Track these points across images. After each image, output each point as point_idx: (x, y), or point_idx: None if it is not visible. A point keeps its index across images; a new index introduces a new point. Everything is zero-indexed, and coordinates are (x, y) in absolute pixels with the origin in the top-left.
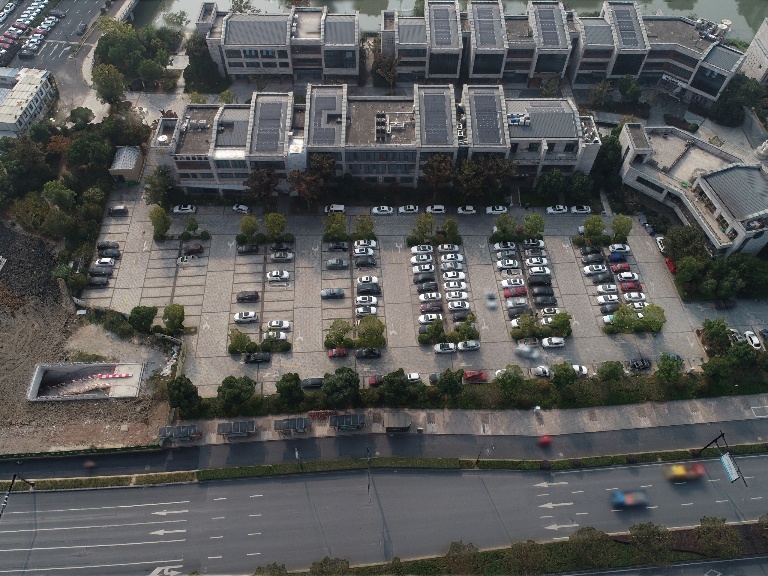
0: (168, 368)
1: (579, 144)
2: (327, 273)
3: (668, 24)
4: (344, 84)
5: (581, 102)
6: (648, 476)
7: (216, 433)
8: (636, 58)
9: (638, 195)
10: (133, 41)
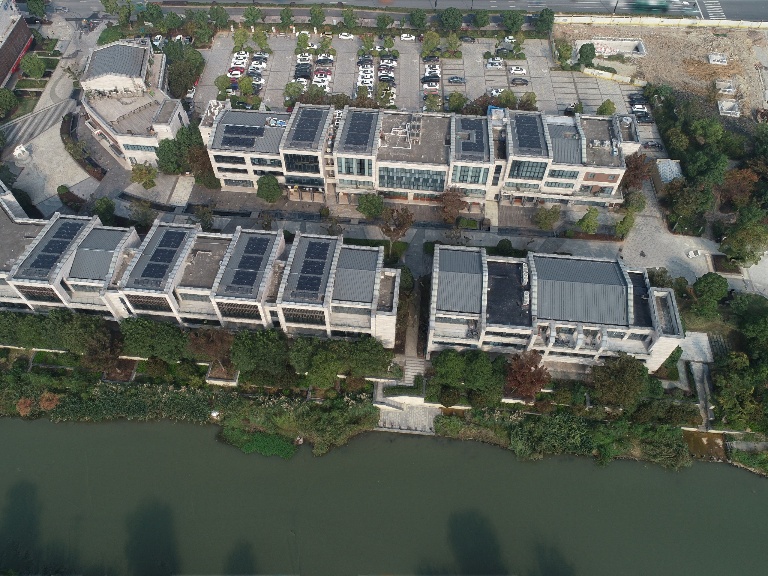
0: None
1: None
2: None
3: None
4: (454, 161)
5: None
6: (287, 2)
7: (522, 26)
8: None
9: None
10: None
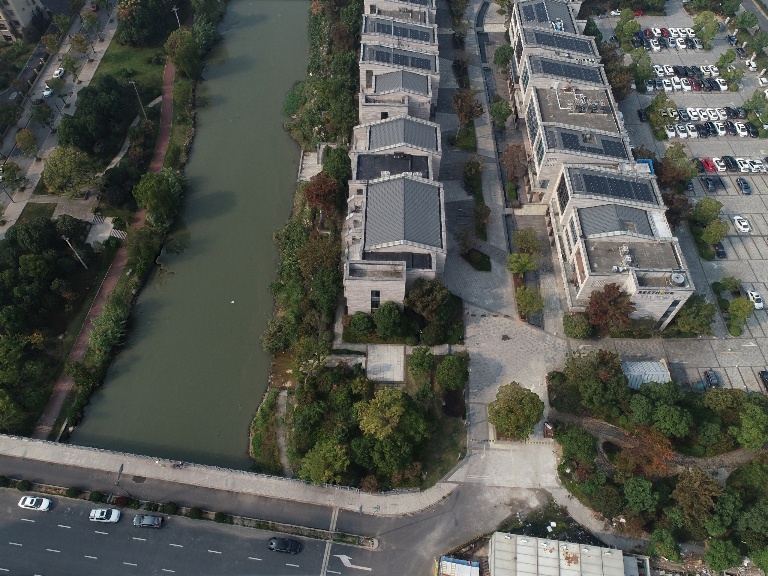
0: None
1: (573, 6)
2: (720, 192)
3: None
4: (541, 124)
5: (449, 25)
6: None
7: None
8: None
9: (583, 8)
10: None
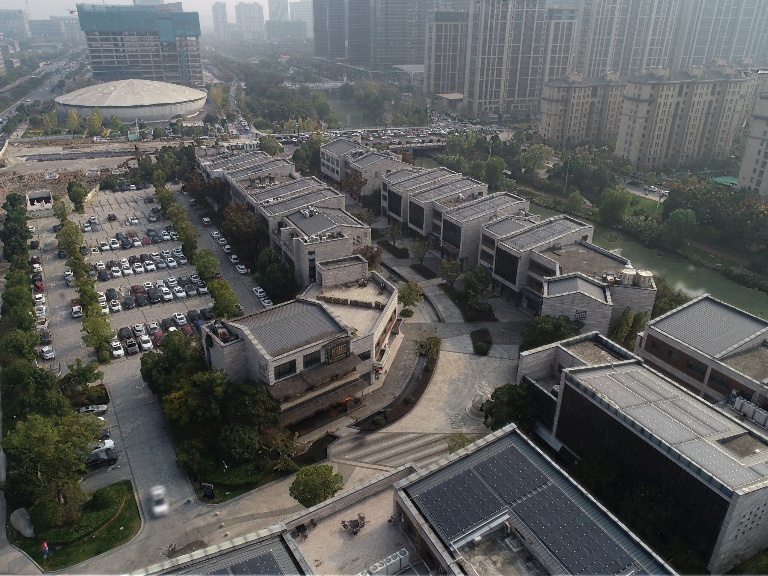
0: None
1: None
2: None
3: (601, 258)
4: None
5: None
6: None
7: None
8: (511, 259)
9: None
10: (316, 143)
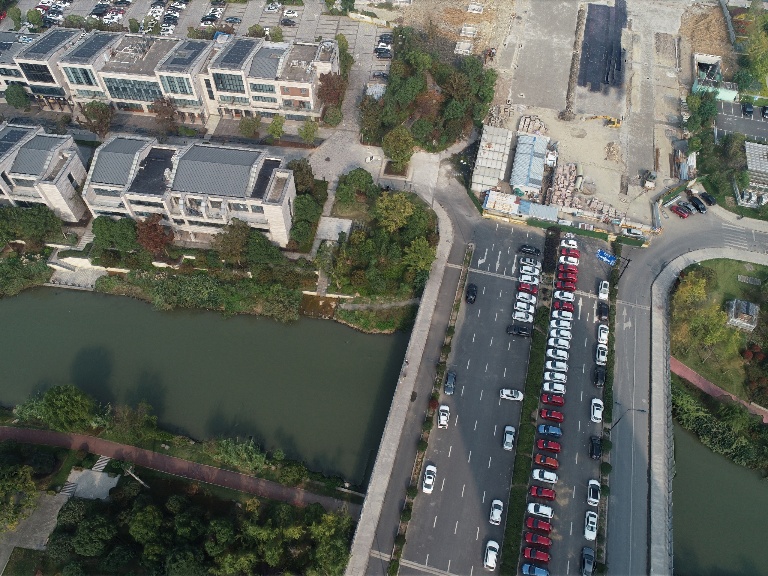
0: (339, 0)
1: None
2: None
3: None
4: (156, 70)
5: None
6: None
7: None
8: None
9: None
10: None
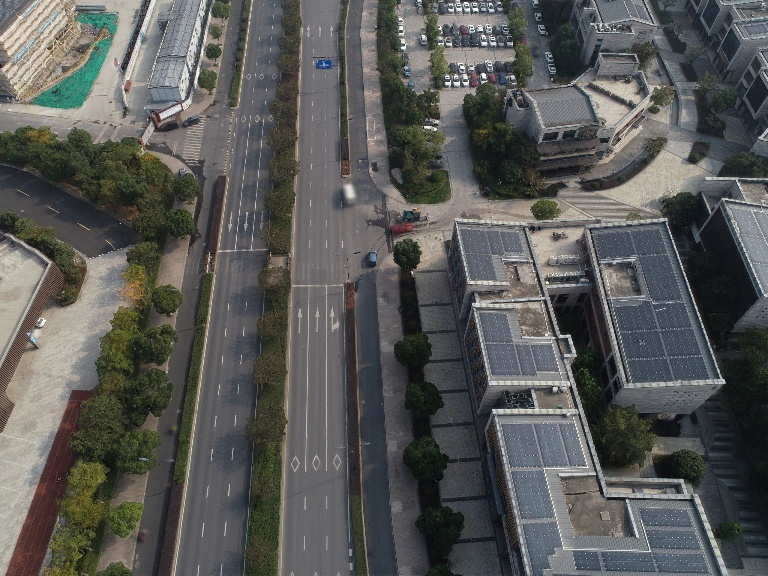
0: None
1: None
2: None
3: None
4: None
5: None
6: None
7: None
8: None
9: None
10: None
